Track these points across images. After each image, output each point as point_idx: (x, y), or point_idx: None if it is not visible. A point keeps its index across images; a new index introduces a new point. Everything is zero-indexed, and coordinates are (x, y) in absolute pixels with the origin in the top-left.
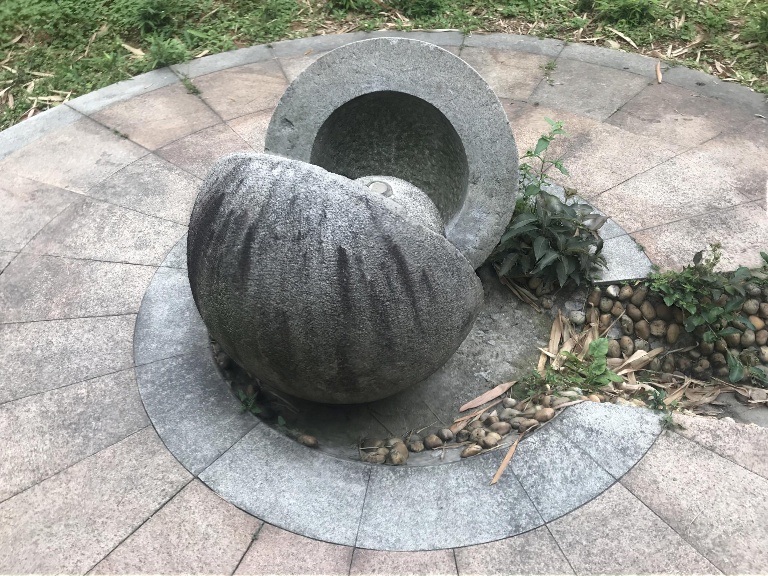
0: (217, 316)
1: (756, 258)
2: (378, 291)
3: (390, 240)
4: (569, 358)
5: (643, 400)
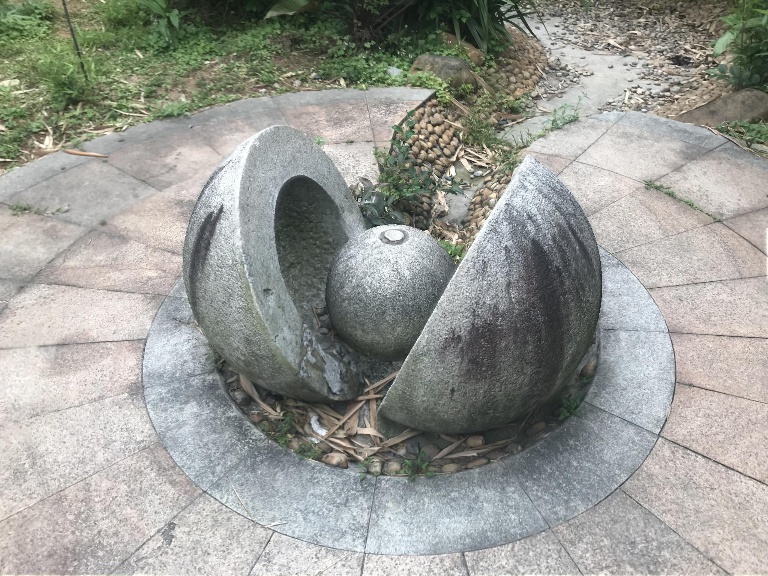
0: None
1: (366, 158)
2: None
3: None
4: None
5: None
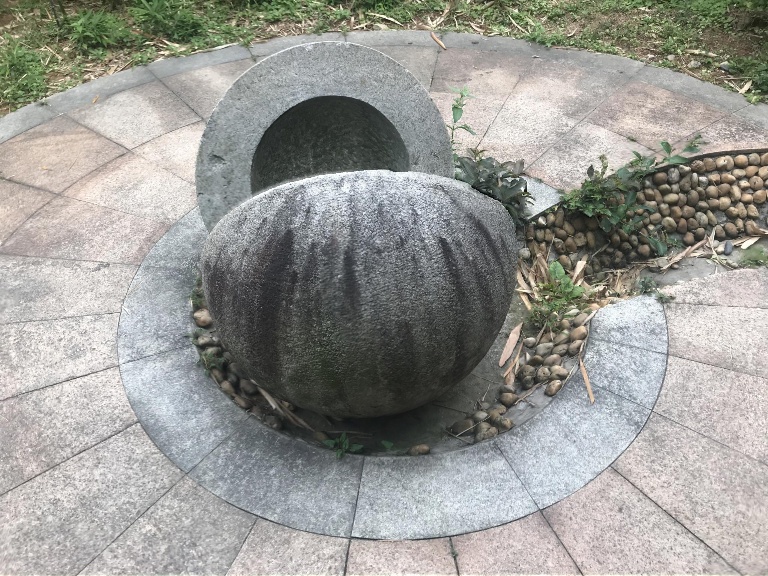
0: (320, 361)
1: (617, 160)
2: (480, 268)
3: (473, 217)
4: (546, 287)
5: None
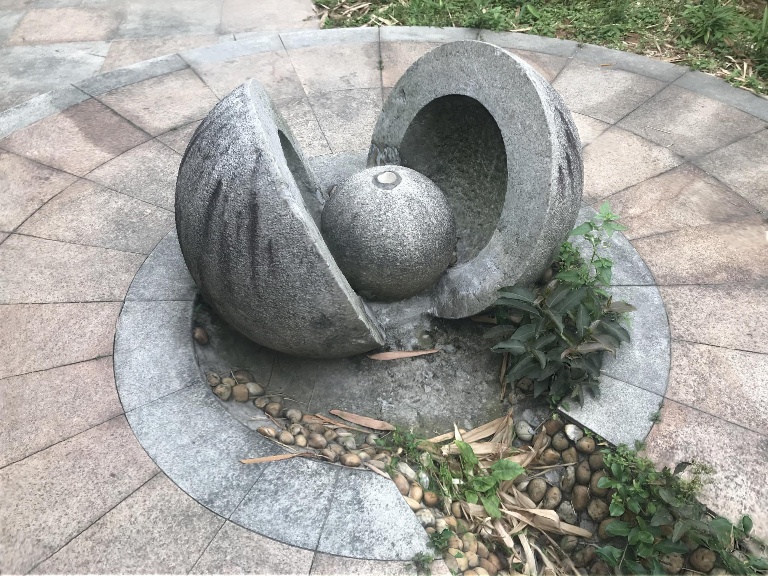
0: None
1: None
2: (228, 233)
3: (254, 197)
4: None
5: (501, 553)
